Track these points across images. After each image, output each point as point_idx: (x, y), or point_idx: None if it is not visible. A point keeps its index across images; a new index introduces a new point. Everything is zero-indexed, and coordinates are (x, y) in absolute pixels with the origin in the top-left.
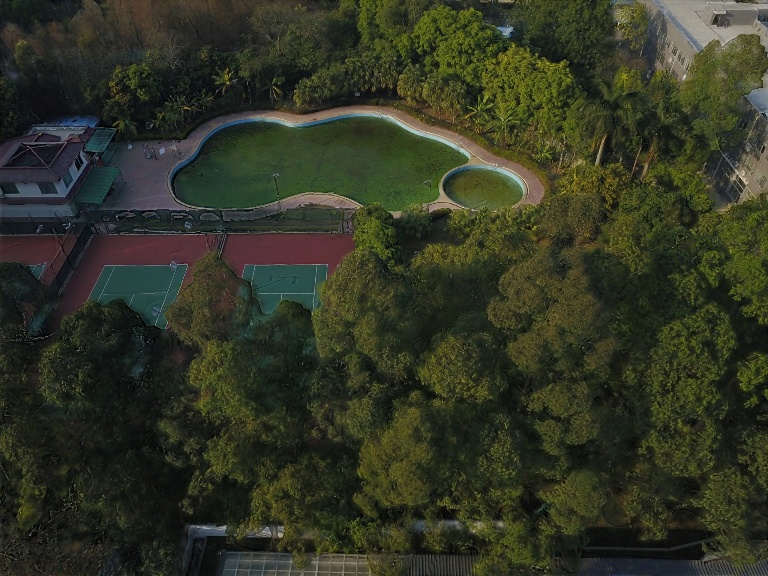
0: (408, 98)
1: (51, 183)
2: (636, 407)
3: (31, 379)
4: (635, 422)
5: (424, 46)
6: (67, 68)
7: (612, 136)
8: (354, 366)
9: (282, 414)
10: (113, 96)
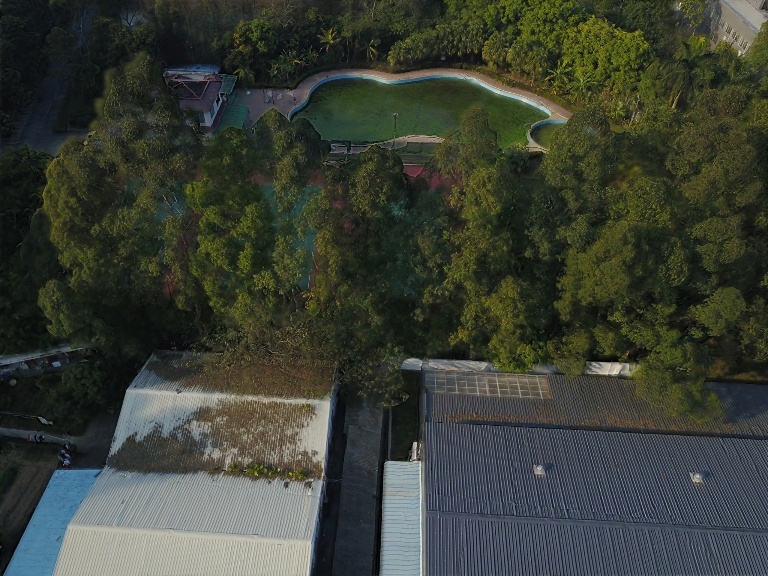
0: (490, 63)
1: (202, 113)
2: (763, 247)
3: (344, 192)
4: (763, 257)
5: (509, 16)
6: (195, 20)
7: (688, 91)
8: (572, 196)
9: (507, 237)
10: (237, 46)
